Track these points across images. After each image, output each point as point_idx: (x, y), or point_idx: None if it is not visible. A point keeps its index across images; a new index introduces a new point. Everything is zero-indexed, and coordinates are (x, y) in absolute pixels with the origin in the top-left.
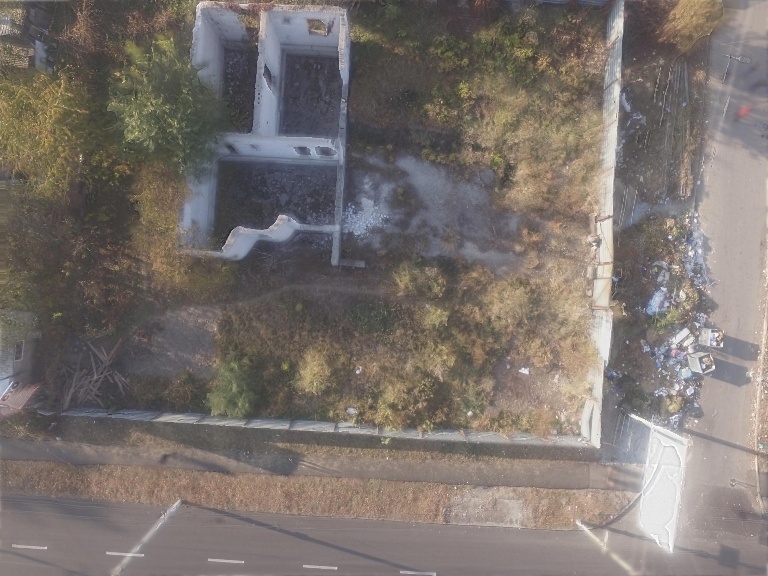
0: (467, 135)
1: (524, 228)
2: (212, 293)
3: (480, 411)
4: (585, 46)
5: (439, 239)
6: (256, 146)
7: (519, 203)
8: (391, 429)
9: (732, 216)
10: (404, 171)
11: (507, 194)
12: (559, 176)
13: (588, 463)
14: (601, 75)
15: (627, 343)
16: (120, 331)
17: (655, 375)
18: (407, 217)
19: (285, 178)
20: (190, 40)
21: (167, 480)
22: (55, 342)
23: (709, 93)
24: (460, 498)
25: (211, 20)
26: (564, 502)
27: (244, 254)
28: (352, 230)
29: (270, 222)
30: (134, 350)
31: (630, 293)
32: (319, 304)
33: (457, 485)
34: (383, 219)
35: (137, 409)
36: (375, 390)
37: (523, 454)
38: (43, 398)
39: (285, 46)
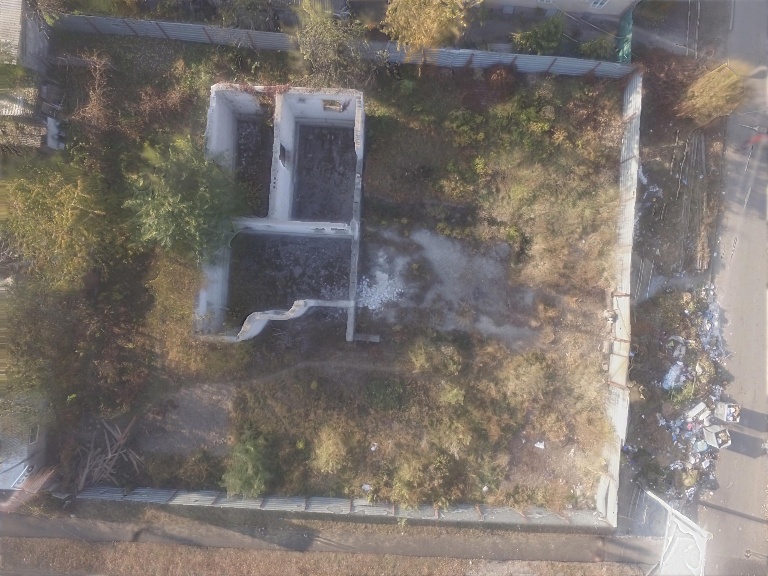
0: (482, 209)
1: (540, 303)
2: (227, 371)
3: (495, 486)
4: (602, 120)
5: (454, 313)
6: (271, 225)
7: (535, 278)
8: (407, 507)
9: (748, 288)
10: (419, 245)
11: (523, 270)
12: (575, 250)
13: (603, 536)
14: (618, 148)
15: (643, 417)
16: (134, 409)
17: (671, 448)
18: (422, 291)
19: (299, 250)
20: (203, 115)
21: (182, 557)
22: (69, 422)
23: (726, 164)
24: (475, 573)
25: (225, 99)
26: (579, 575)
27: (259, 331)
28: (367, 304)
29: (284, 295)
30: (148, 429)
31: (646, 368)
32: (334, 381)
33: (472, 559)
34: (398, 293)
35: (152, 487)
36: (390, 467)
37: (538, 528)
38: (58, 480)
39: (299, 119)
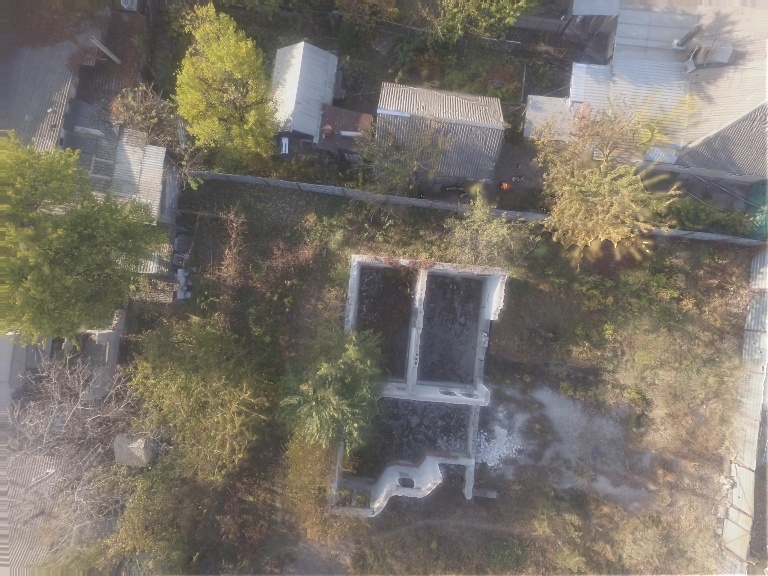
0: (606, 370)
1: (659, 467)
2: None
3: None
4: (731, 289)
5: (572, 472)
6: None
7: (656, 443)
8: None
9: None
10: (540, 402)
11: (646, 436)
12: (696, 415)
13: None
14: (744, 316)
15: None
16: (252, 561)
17: None
18: (541, 449)
19: None
20: (332, 268)
21: None
22: None
23: None
24: None
25: None
26: None
27: None
28: (485, 460)
29: (400, 444)
30: None
31: (760, 534)
32: (453, 539)
33: None
34: (516, 449)
35: None
36: None
37: None
38: None
39: None
